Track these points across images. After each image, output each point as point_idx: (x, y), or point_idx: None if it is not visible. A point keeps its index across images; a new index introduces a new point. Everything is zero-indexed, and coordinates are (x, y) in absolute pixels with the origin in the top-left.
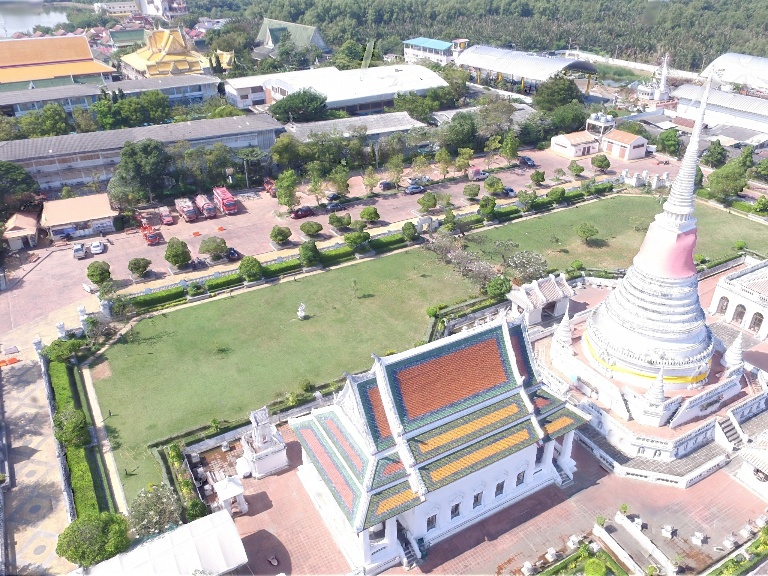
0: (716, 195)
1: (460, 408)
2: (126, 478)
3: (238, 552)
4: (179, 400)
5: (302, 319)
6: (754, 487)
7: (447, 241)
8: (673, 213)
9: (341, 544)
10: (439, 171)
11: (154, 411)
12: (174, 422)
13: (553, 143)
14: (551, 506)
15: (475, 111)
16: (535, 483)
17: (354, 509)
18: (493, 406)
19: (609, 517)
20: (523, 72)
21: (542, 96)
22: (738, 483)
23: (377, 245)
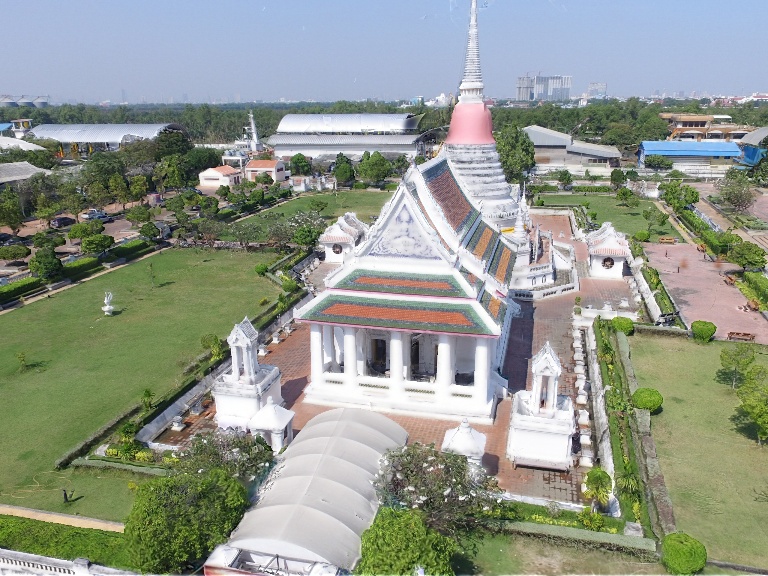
0: (373, 180)
1: (469, 226)
2: (70, 507)
3: (393, 428)
4: (33, 420)
5: (112, 315)
6: (606, 276)
7: (213, 223)
8: (474, 89)
9: (436, 414)
10: (118, 200)
11: (3, 443)
12: (60, 437)
13: (202, 179)
14: (532, 327)
15: (115, 151)
16: (508, 316)
17: (476, 321)
18: (479, 229)
19: (570, 317)
20: (119, 138)
21: (160, 148)
22: (596, 279)
23: (122, 252)
